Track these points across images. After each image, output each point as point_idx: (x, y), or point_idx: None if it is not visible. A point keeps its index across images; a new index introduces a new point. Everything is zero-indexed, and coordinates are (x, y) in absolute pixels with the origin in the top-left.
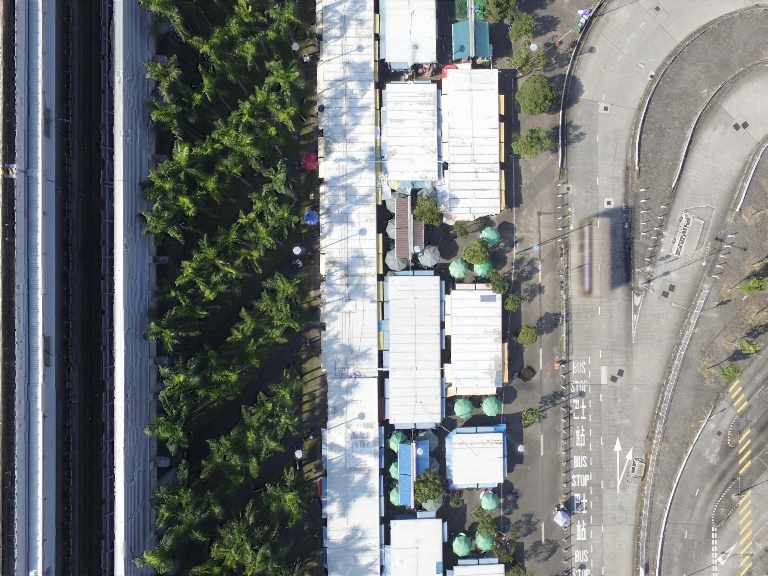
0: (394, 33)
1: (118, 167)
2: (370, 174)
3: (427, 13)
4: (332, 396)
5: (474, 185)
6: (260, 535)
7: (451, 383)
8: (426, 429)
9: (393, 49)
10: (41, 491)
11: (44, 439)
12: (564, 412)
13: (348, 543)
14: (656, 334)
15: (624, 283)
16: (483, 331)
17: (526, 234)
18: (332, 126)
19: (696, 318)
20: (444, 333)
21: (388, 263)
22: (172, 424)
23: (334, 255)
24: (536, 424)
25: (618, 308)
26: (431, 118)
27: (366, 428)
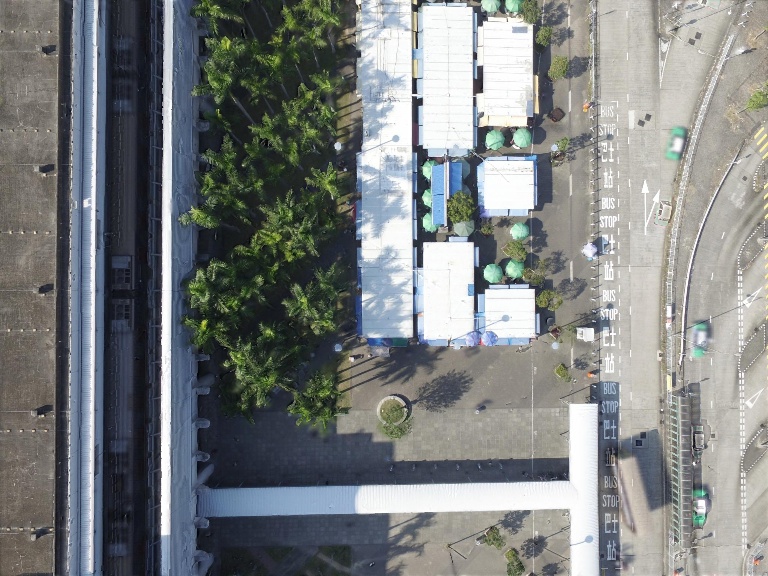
0: None
1: None
2: None
3: None
4: (367, 119)
5: None
6: (301, 209)
7: (483, 112)
8: (458, 157)
9: None
10: (95, 122)
11: (98, 78)
12: (592, 154)
13: (382, 263)
14: (683, 80)
15: (651, 30)
16: (515, 61)
17: None
18: None
19: (722, 61)
20: (476, 64)
21: None
22: (220, 75)
23: None
24: (565, 164)
25: (645, 54)
26: None
27: (400, 152)
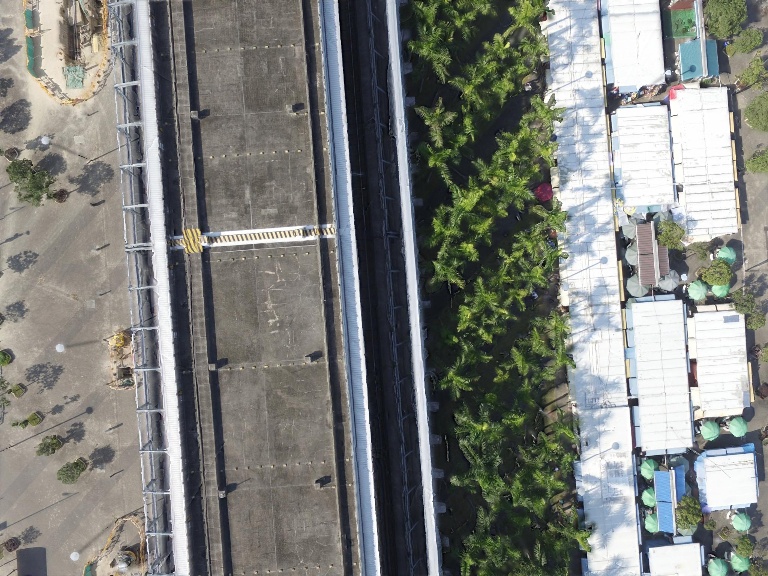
0: (621, 57)
1: (407, 217)
2: (607, 201)
3: (653, 34)
4: (584, 428)
5: (711, 206)
6: None
7: (699, 406)
8: (676, 454)
9: (622, 73)
10: (378, 553)
11: None
12: None
13: (610, 574)
14: None
15: None
16: (728, 352)
17: (754, 250)
18: (566, 155)
19: None
20: (688, 356)
21: (630, 290)
22: (490, 475)
23: (576, 285)
24: None
25: None
26: (664, 141)
27: (619, 457)
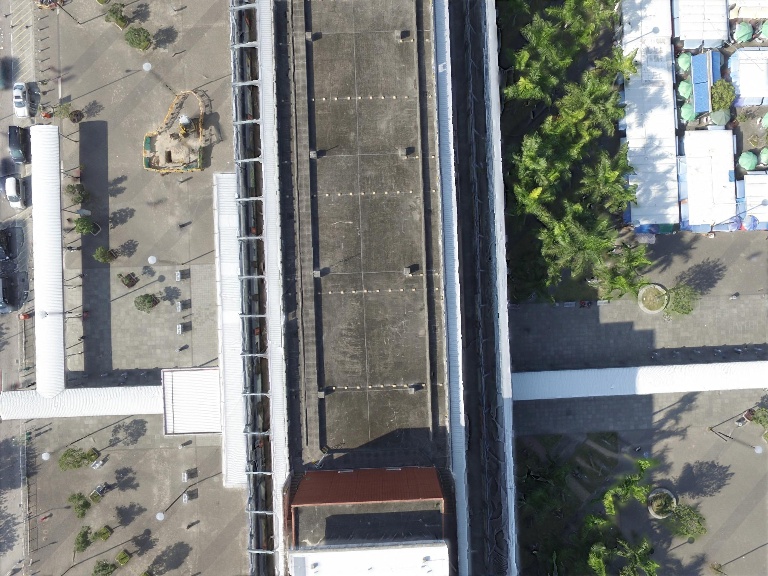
0: None
1: None
2: None
3: None
4: (627, 12)
5: None
6: (609, 85)
7: (735, 3)
8: (712, 48)
9: None
10: None
11: None
12: None
13: (647, 151)
14: None
15: None
16: None
17: None
18: None
19: None
20: None
21: None
22: None
23: None
24: None
25: None
26: None
27: (659, 43)
